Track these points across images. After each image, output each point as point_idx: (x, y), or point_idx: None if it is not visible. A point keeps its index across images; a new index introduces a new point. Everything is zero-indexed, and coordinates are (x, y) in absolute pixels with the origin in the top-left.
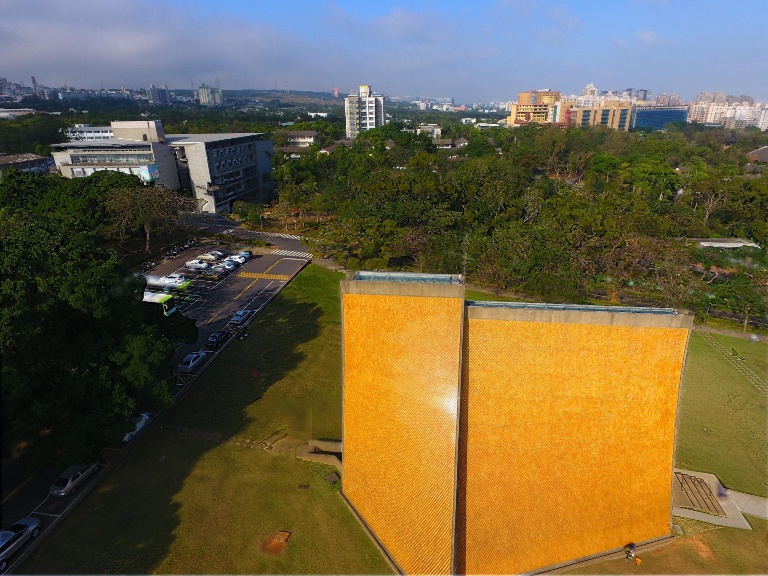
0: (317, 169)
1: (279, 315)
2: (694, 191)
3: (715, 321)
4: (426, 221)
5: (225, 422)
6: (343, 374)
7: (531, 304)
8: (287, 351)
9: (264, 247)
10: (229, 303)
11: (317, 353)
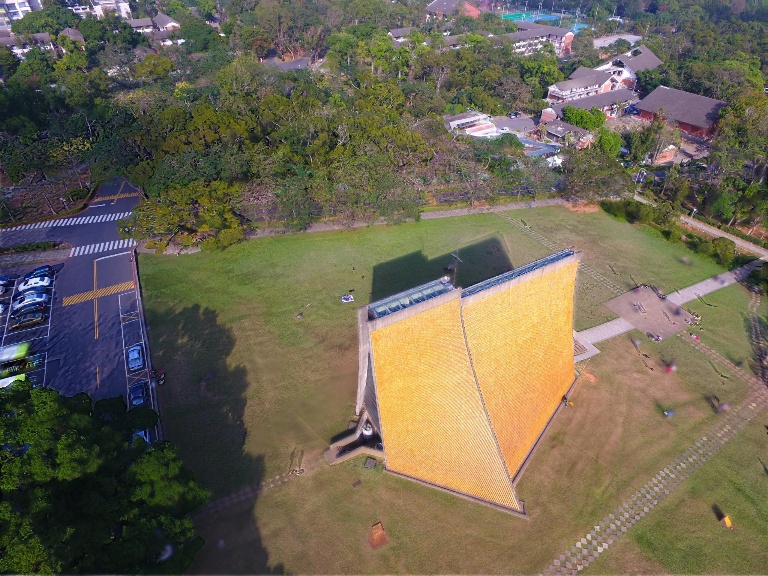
0: (39, 114)
1: (173, 336)
2: (423, 65)
3: (501, 199)
4: (257, 173)
5: (239, 474)
6: (376, 390)
7: (493, 279)
8: (222, 372)
9: (51, 250)
10: (96, 347)
11: (251, 360)
